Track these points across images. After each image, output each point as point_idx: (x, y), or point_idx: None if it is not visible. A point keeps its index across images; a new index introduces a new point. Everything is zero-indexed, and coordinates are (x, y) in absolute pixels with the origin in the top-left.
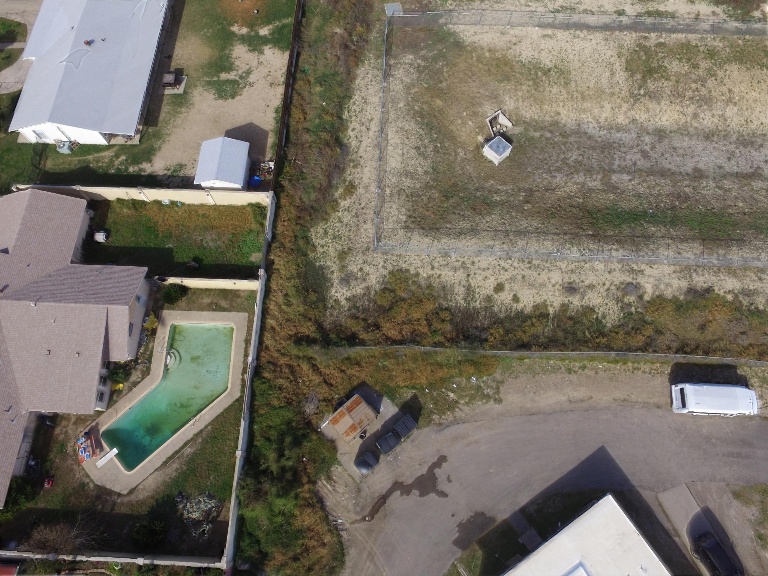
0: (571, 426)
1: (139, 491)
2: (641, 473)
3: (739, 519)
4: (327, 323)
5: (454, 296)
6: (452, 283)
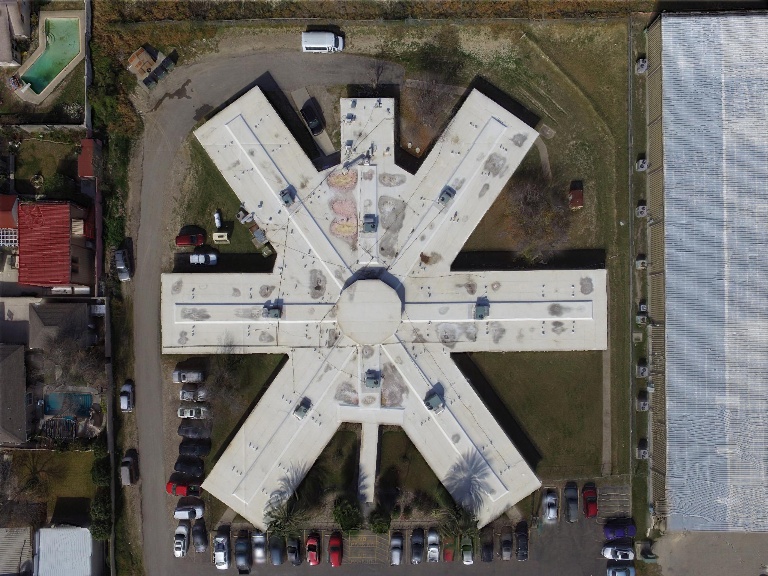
0: (253, 62)
1: (45, 103)
2: (285, 83)
3: (328, 102)
4: (126, 12)
5: None
6: None
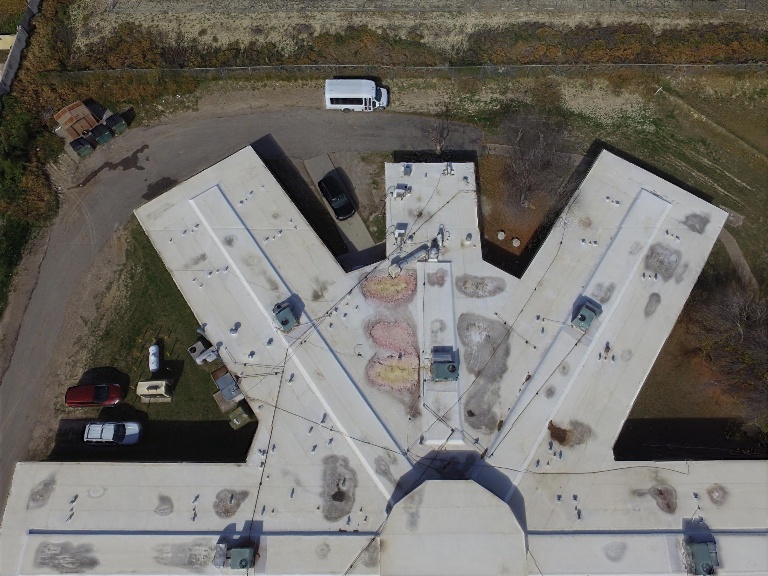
0: (248, 123)
1: None
2: (295, 149)
3: (363, 174)
4: (70, 64)
5: (168, 40)
6: (167, 31)
